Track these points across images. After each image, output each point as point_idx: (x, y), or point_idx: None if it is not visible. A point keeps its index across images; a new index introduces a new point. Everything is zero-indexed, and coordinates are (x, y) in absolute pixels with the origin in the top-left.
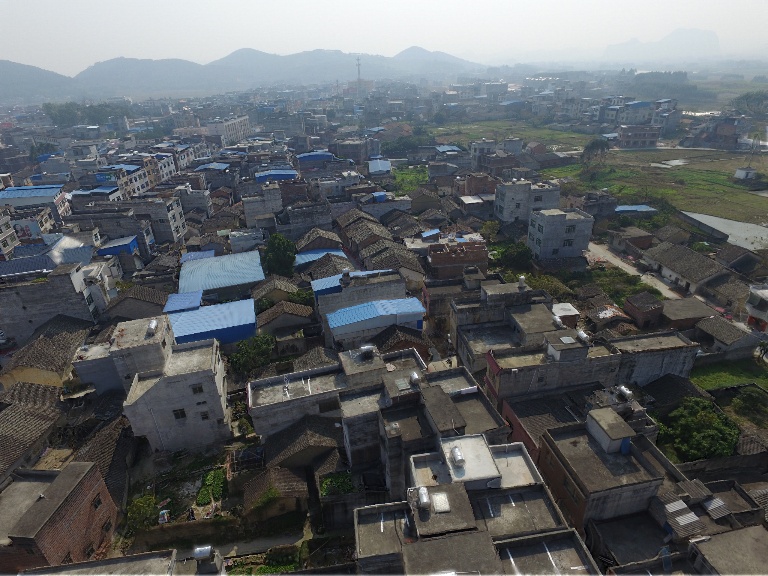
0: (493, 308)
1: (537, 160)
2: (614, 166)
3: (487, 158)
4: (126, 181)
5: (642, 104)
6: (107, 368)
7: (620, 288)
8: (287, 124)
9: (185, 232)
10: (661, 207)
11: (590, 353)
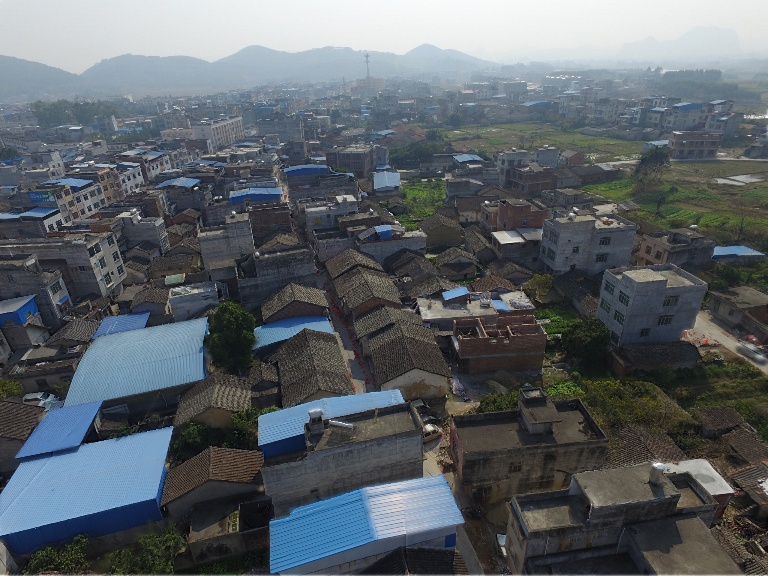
0: (599, 527)
1: (578, 174)
2: (672, 182)
3: (518, 172)
4: (71, 200)
5: (693, 106)
6: None
7: (758, 402)
8: (283, 126)
9: (123, 278)
10: (761, 247)
11: None
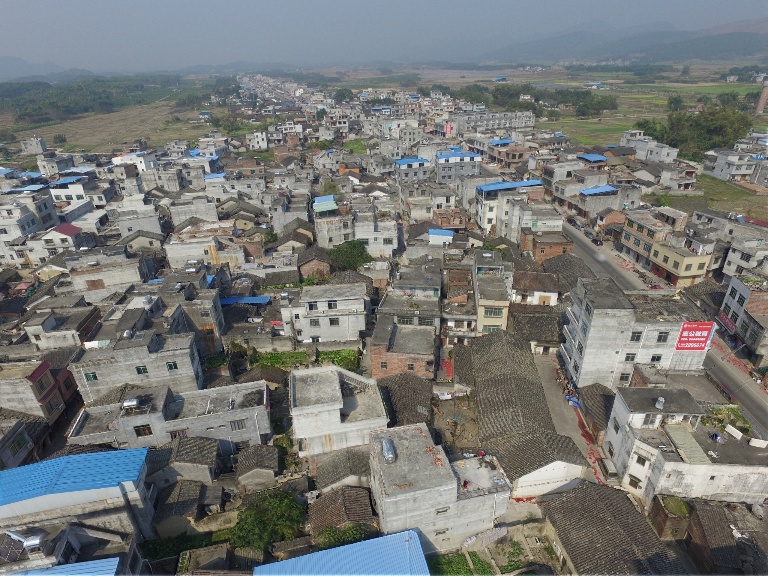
0: None
1: None
2: None
3: None
4: None
5: None
6: None
7: None
8: None
9: None
10: None
11: None
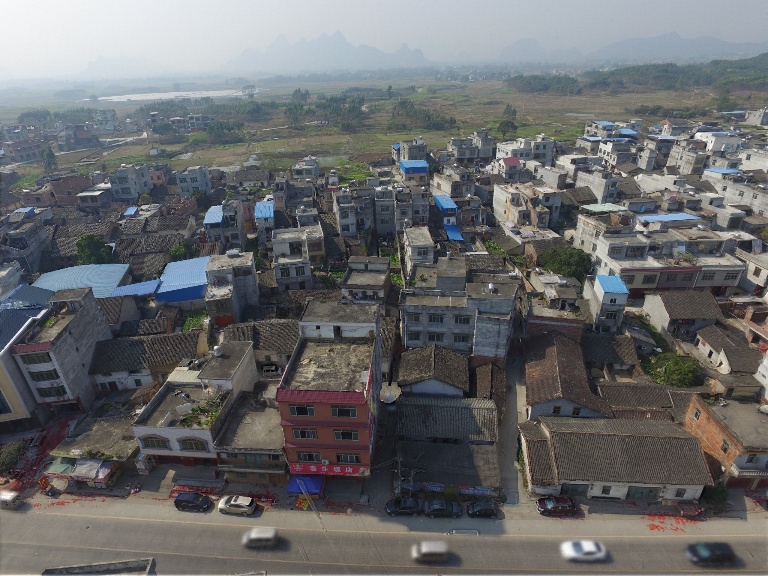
0: None
1: None
2: None
3: None
4: None
5: None
6: (235, 295)
7: None
8: None
9: None
10: None
11: None
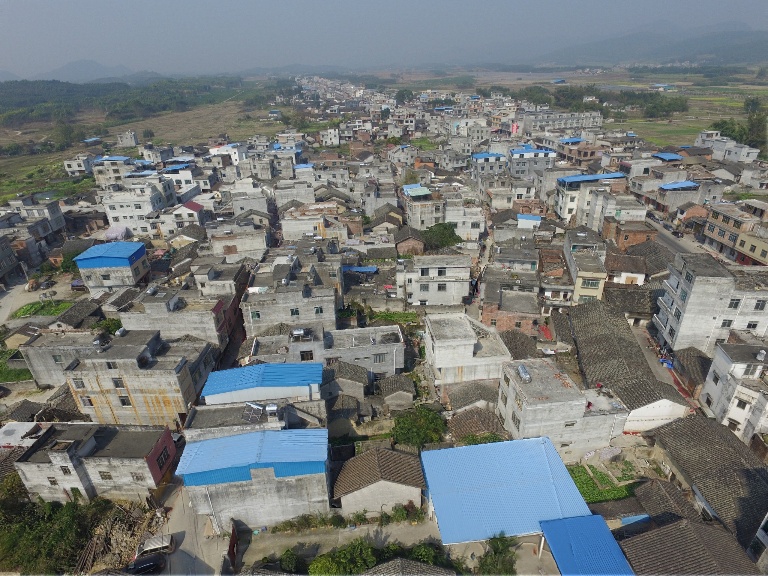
0: None
1: None
2: None
3: None
4: None
5: None
6: None
7: None
8: None
9: None
10: None
11: (143, 310)
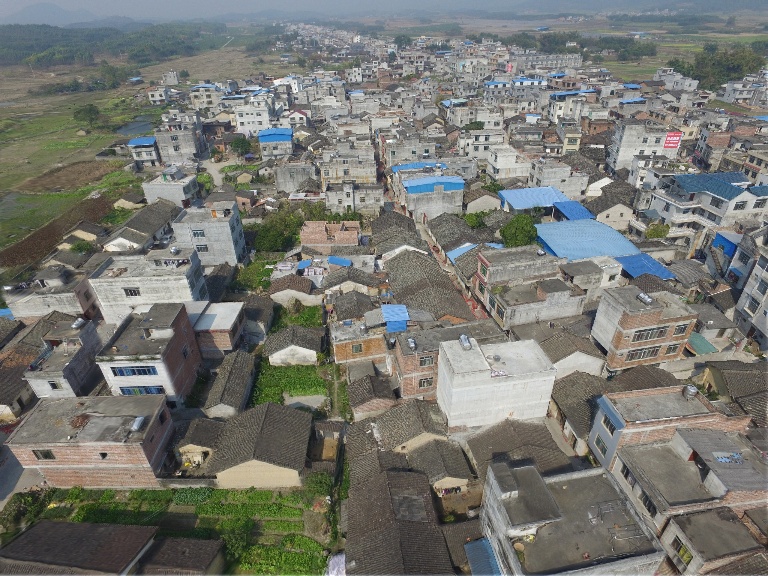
0: None
1: None
2: None
3: None
4: None
5: None
6: None
7: None
8: None
9: None
10: None
11: None
